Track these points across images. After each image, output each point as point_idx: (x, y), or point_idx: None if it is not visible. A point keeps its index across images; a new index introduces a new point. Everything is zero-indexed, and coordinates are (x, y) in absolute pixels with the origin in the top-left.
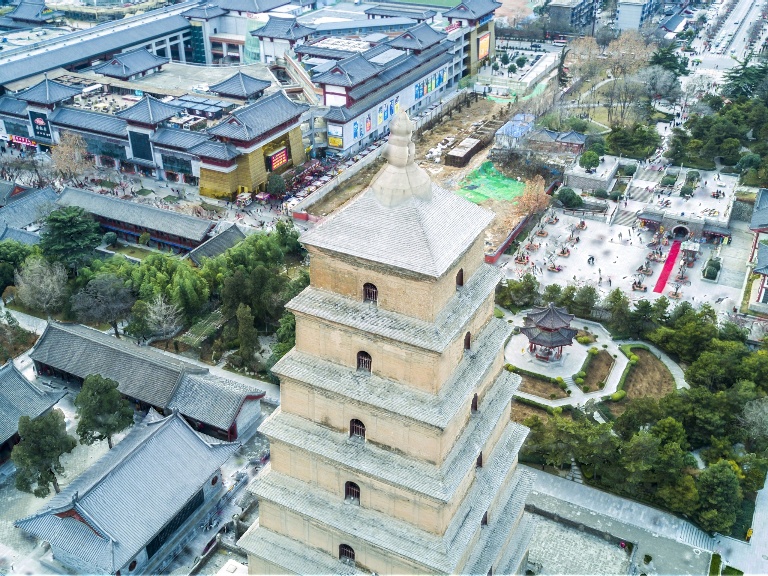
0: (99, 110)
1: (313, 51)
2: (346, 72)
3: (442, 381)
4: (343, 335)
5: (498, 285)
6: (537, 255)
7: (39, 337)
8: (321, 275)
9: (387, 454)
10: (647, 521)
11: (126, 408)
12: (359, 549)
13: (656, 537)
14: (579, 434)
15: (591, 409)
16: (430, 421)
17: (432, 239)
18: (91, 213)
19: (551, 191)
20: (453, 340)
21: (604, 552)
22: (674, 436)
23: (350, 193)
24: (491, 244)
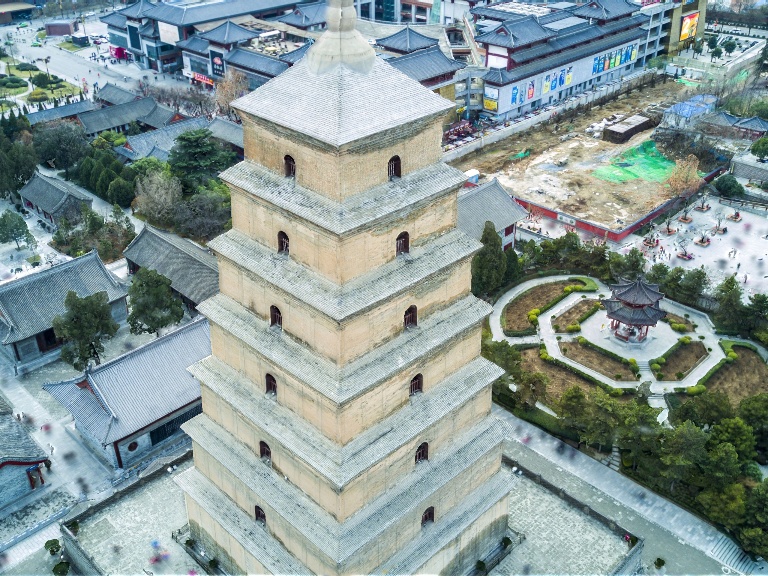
0: (269, 53)
1: (489, 13)
2: (511, 33)
3: (354, 274)
4: (266, 212)
5: (600, 257)
6: (671, 240)
7: (135, 238)
8: (252, 146)
9: (298, 347)
10: (678, 525)
11: (175, 306)
12: (274, 448)
13: (682, 544)
14: (618, 413)
15: (644, 391)
16: (327, 311)
17: (349, 110)
18: (230, 143)
19: (711, 177)
20: (373, 232)
21: (603, 540)
22: (737, 439)
23: (491, 157)
24: (622, 222)
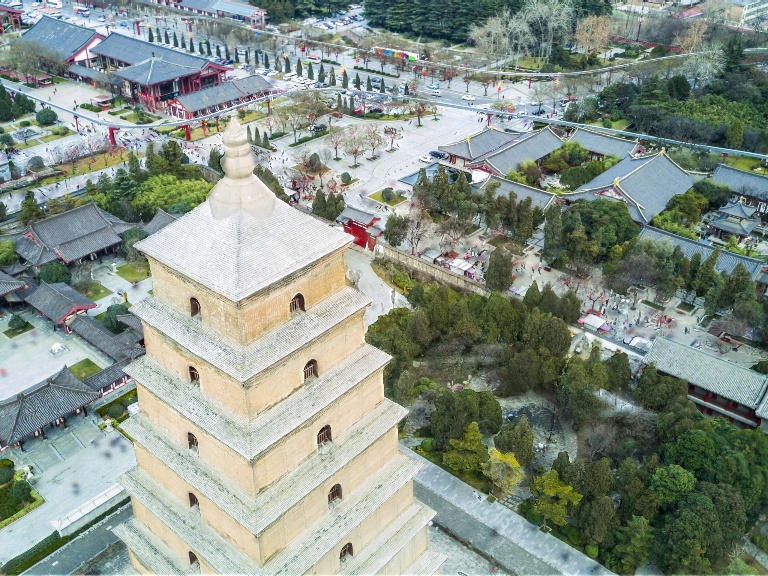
0: None
1: None
2: None
3: None
4: None
5: None
6: None
7: None
8: None
9: None
10: None
11: None
12: None
13: None
14: None
15: None
16: None
17: None
18: None
19: None
20: None
21: None
22: None
23: None
24: None
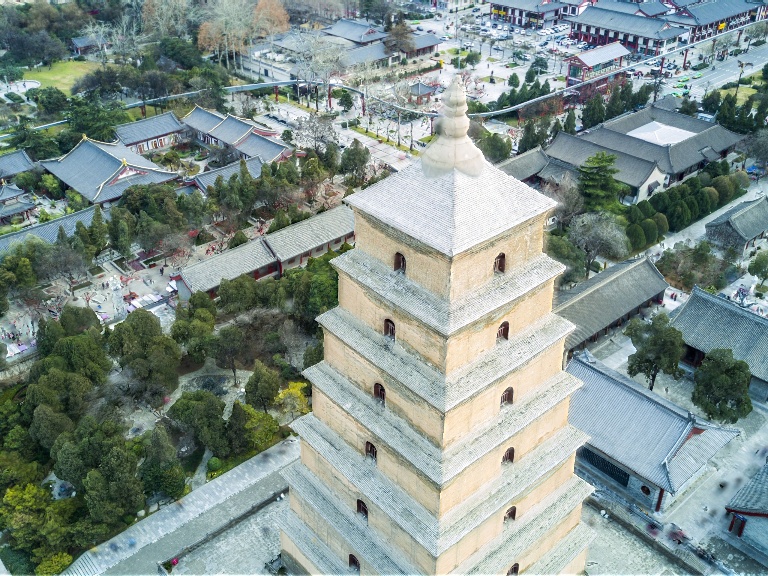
0: None
1: None
2: None
3: None
4: None
5: None
6: None
7: None
8: None
9: None
10: None
11: (724, 403)
12: None
13: None
14: None
15: None
16: None
17: (382, 189)
18: None
19: None
20: None
21: None
22: None
23: None
24: None
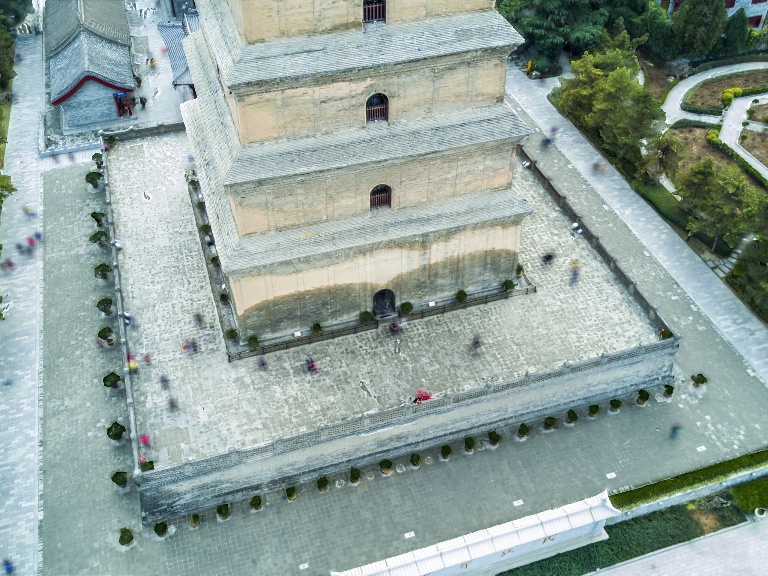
0: None
1: None
2: None
3: None
4: None
5: None
6: None
7: None
8: None
9: None
10: (759, 354)
11: None
12: None
13: (749, 374)
14: (741, 199)
15: None
16: None
17: None
18: None
19: None
20: None
21: (630, 325)
22: None
23: None
24: None
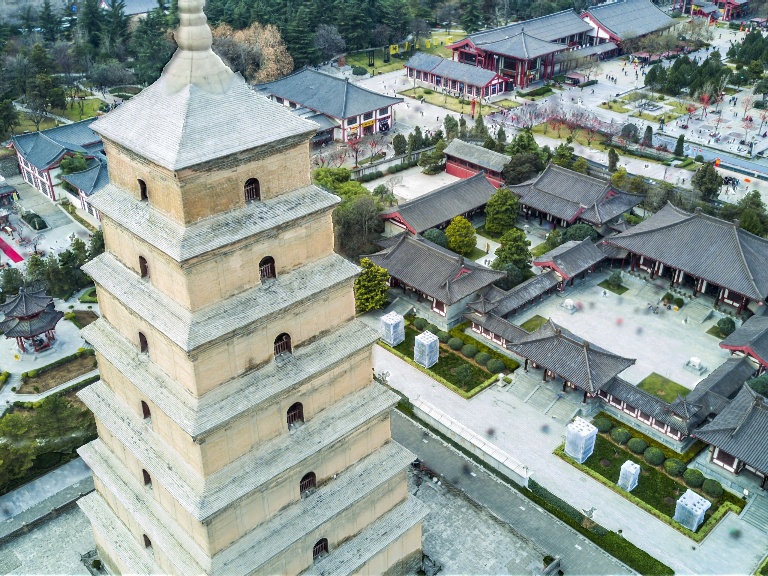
0: None
1: None
2: None
3: None
4: (243, 253)
5: None
6: None
7: None
8: (197, 203)
9: (316, 345)
10: None
11: None
12: (319, 465)
13: None
14: None
15: None
16: (350, 274)
17: None
18: None
19: None
20: None
21: None
22: None
23: None
24: None
